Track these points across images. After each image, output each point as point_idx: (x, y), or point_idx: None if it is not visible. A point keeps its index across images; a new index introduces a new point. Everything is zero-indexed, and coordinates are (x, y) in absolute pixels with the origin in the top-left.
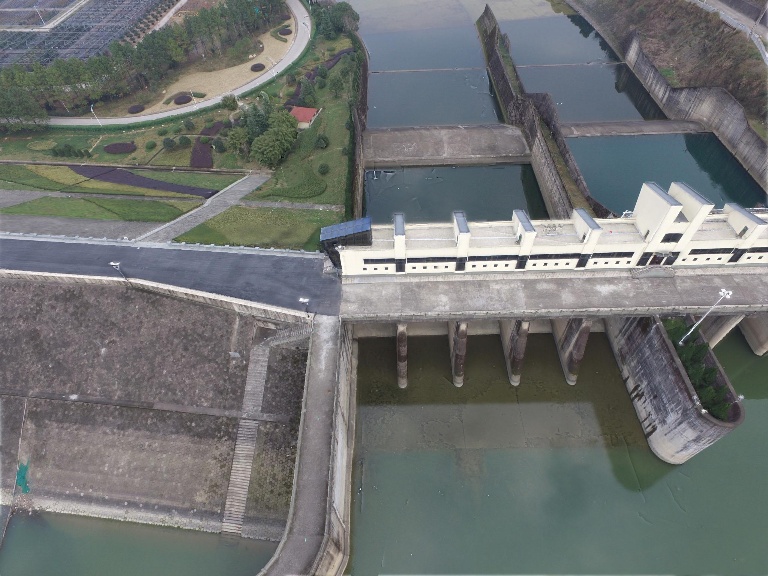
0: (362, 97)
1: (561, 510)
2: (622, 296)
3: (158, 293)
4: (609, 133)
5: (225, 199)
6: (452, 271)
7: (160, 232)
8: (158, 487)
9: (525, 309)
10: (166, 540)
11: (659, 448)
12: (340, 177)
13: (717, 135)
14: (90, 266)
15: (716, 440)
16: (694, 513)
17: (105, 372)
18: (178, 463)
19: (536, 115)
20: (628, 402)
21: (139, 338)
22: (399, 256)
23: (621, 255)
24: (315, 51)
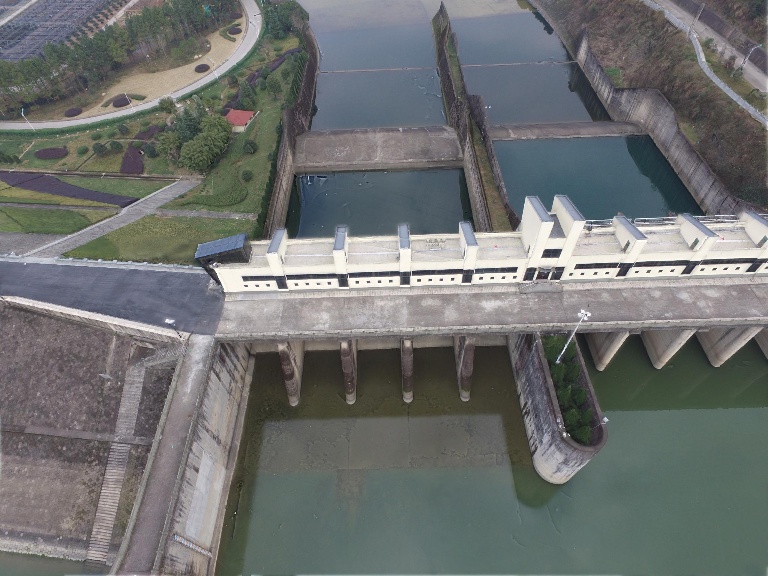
0: (304, 99)
1: (435, 533)
2: (506, 312)
3: (36, 312)
4: (545, 136)
5: (142, 208)
6: (336, 287)
7: (55, 246)
8: (25, 514)
9: (405, 327)
10: (29, 569)
11: (540, 468)
12: (262, 184)
13: (652, 138)
14: None
15: (584, 463)
16: (569, 535)
17: None
18: (46, 489)
19: (467, 119)
20: (519, 419)
21: (14, 359)
22: (277, 273)
23: (505, 270)
24: (260, 51)
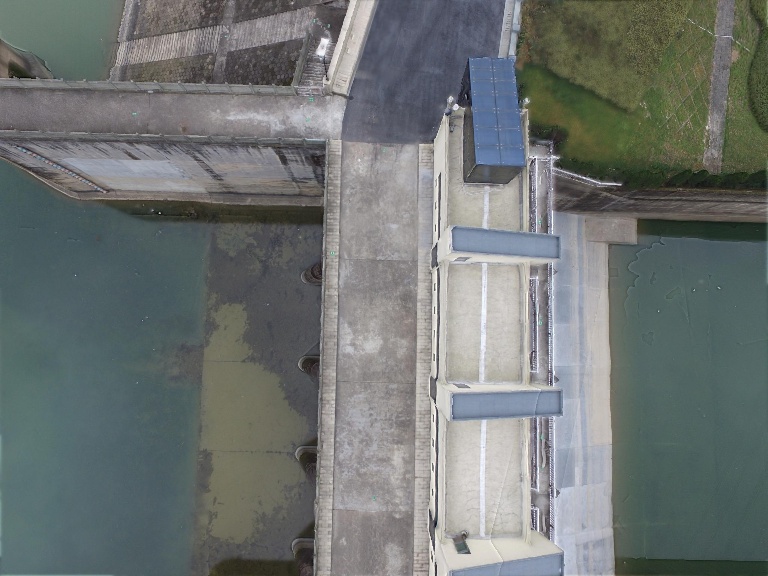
0: None
1: (114, 477)
2: None
3: None
4: None
5: None
6: None
7: None
8: None
9: (336, 506)
10: None
11: None
12: None
13: None
14: None
15: None
16: None
17: None
18: None
19: None
20: None
21: None
22: None
23: None
24: None
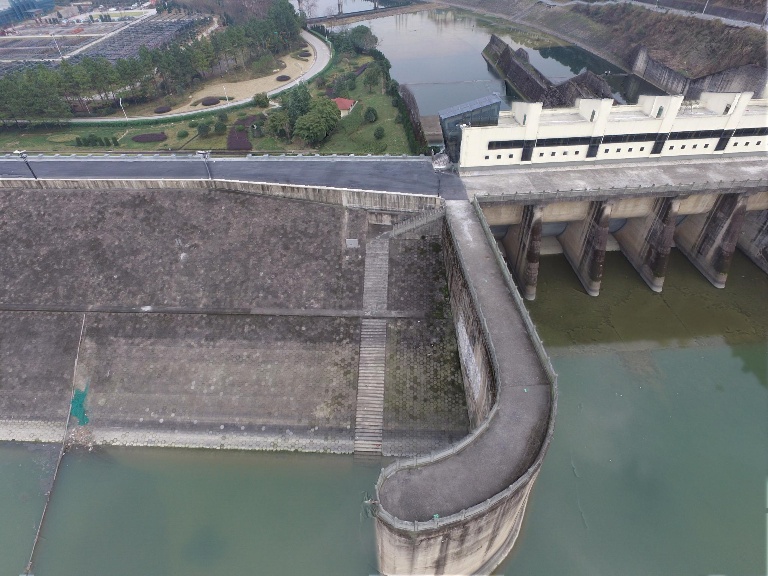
0: None
1: None
2: None
3: (247, 193)
4: None
5: None
6: (582, 159)
7: None
8: (264, 404)
9: None
10: (281, 468)
11: None
12: (399, 138)
13: None
14: (160, 176)
15: None
16: None
17: (186, 279)
18: (288, 374)
19: (583, 87)
20: None
21: (227, 240)
22: (529, 135)
23: (764, 132)
24: None
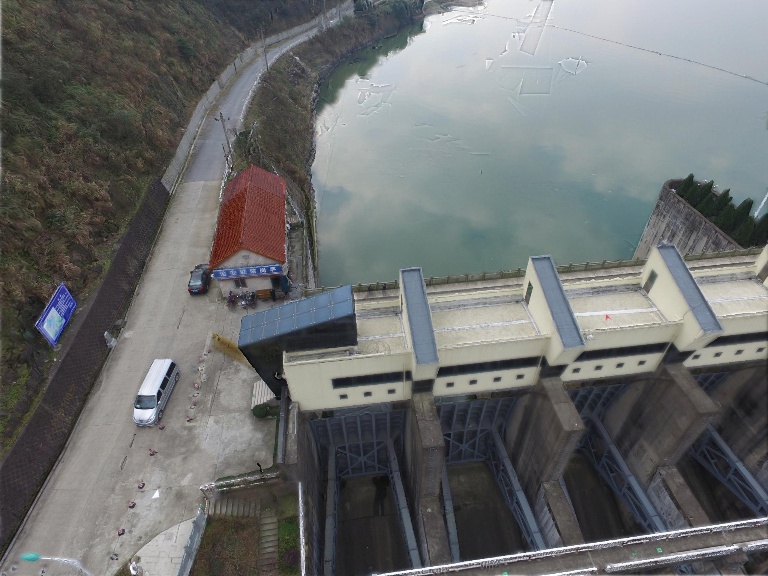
0: None
1: None
2: None
3: None
4: None
5: None
6: None
7: None
8: None
9: None
10: None
11: None
12: None
13: None
14: None
15: None
16: (618, 239)
17: None
18: None
19: None
20: None
21: None
22: None
23: None
24: None
